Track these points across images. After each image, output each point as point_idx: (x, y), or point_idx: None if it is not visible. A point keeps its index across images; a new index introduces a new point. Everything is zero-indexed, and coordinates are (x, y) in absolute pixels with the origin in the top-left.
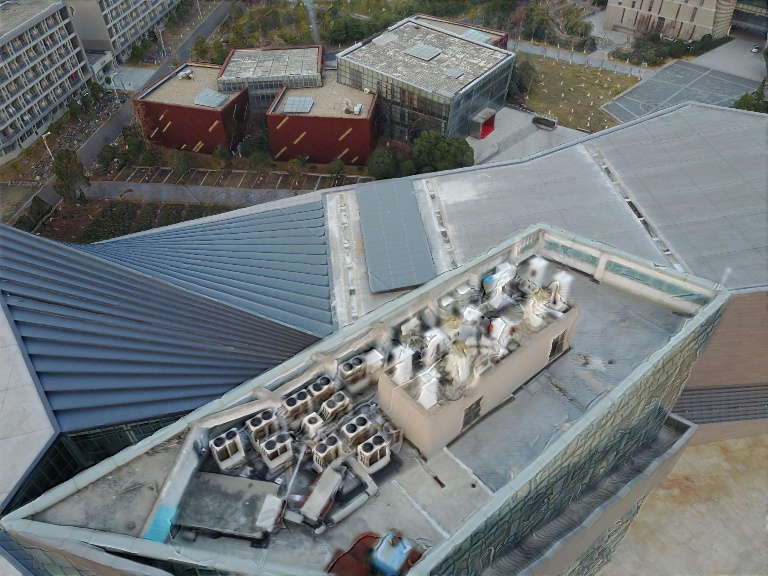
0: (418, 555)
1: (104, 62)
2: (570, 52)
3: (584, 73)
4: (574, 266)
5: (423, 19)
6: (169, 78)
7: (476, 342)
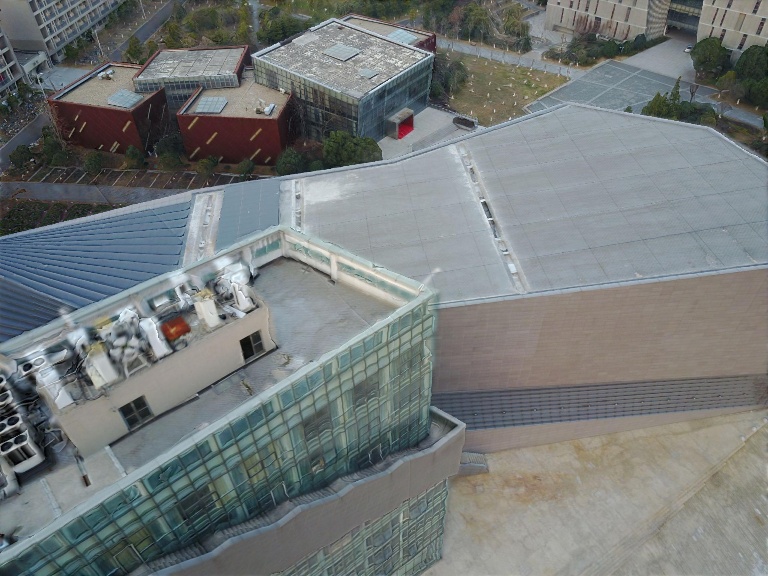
0: None
1: (37, 62)
2: (505, 52)
3: (514, 73)
4: (316, 267)
5: (355, 19)
6: (89, 78)
7: (125, 342)
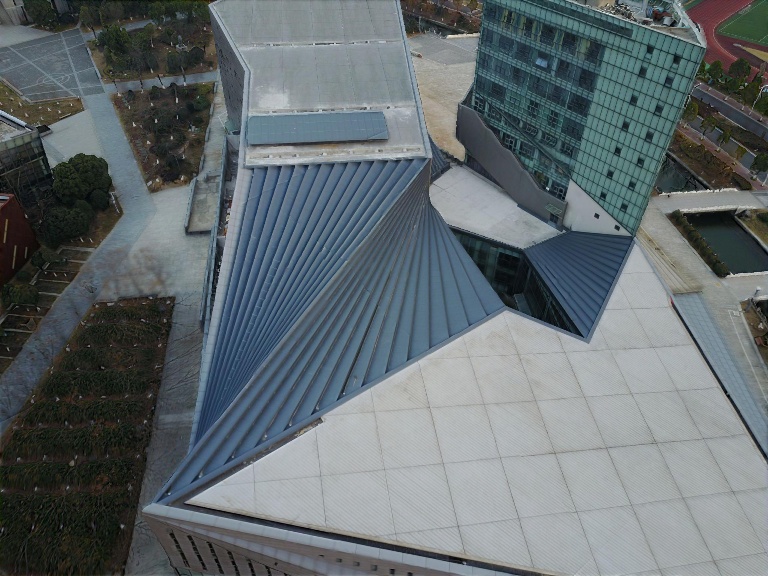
0: (659, 2)
1: None
2: None
3: None
4: None
5: None
6: None
7: None
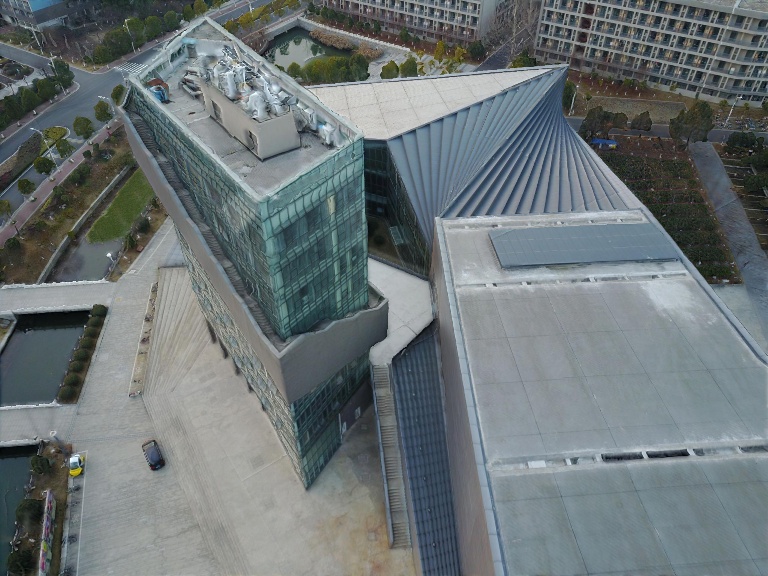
0: None
1: None
2: None
3: None
4: None
5: None
6: None
7: None
